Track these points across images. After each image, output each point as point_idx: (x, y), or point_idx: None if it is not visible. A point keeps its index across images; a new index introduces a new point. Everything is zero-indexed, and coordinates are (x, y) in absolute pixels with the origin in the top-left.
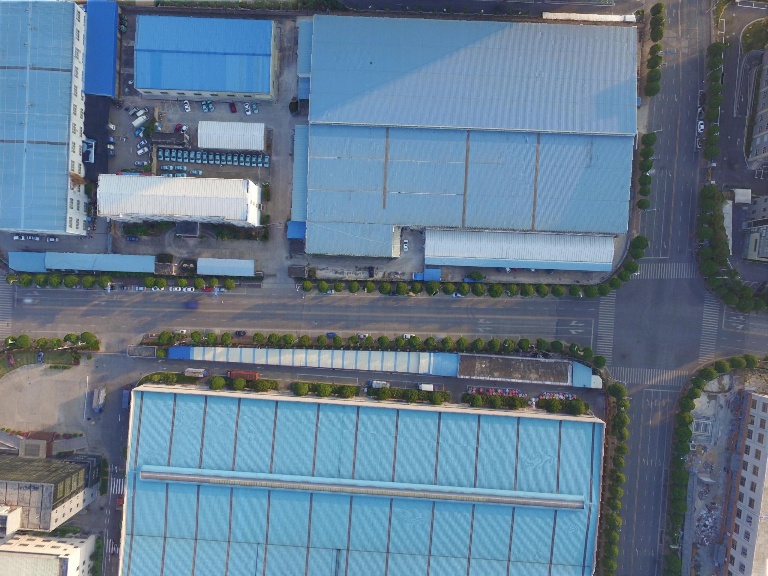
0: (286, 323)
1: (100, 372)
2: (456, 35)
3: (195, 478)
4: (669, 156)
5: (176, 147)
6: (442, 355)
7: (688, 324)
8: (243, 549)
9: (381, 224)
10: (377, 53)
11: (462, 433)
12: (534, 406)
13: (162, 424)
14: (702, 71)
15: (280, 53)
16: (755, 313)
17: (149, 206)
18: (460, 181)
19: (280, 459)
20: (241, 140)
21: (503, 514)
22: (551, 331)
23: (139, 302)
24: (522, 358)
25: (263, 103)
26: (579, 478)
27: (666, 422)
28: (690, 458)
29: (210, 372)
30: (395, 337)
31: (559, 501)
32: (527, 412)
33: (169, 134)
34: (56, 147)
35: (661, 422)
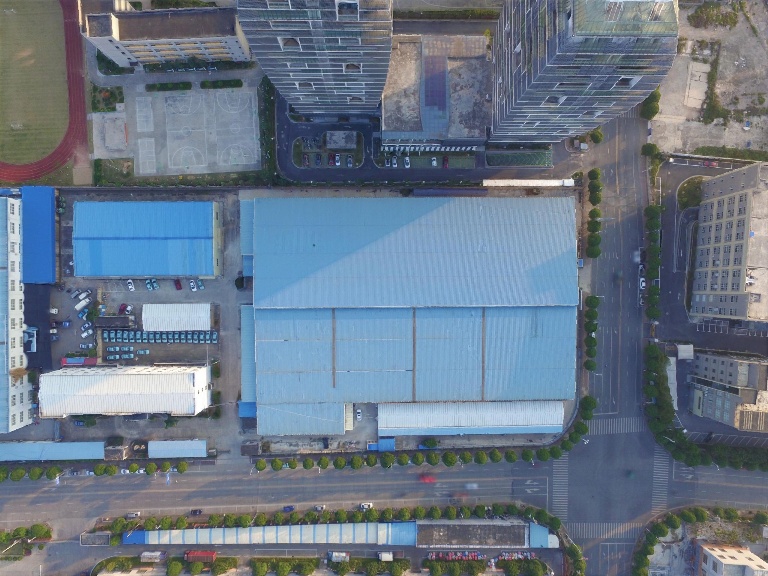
0: (242, 499)
1: (53, 560)
2: (398, 213)
3: None
4: (613, 313)
5: (121, 329)
6: (400, 525)
7: (640, 477)
8: None
9: (332, 403)
10: (319, 234)
11: None
12: (494, 567)
13: None
14: (641, 229)
15: (224, 227)
16: None
17: (93, 405)
18: (408, 357)
19: None
20: (187, 322)
21: None
22: (507, 491)
23: (90, 486)
24: (479, 524)
25: None
26: None
27: (623, 574)
28: None
29: (167, 554)
30: (353, 506)
31: None
32: None
33: (113, 318)
34: None
35: (618, 574)
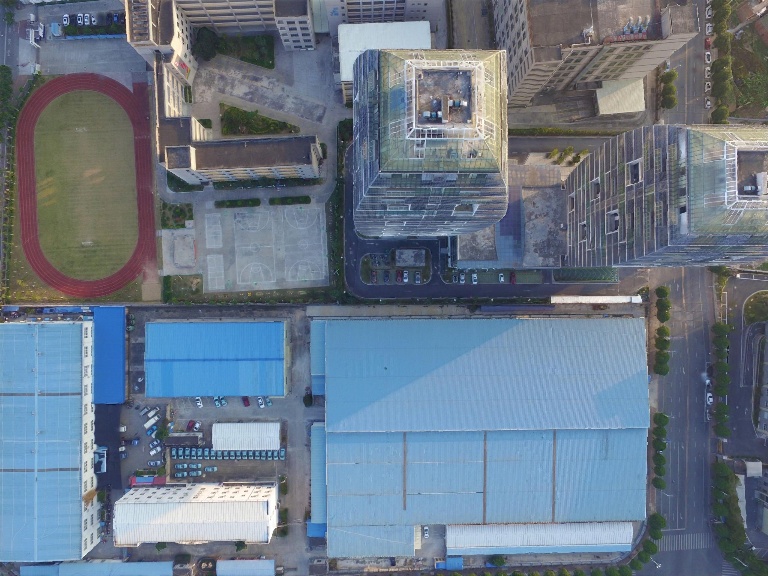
0: None
1: None
2: (468, 335)
3: None
4: (680, 428)
5: (190, 446)
6: None
7: None
8: None
9: (402, 525)
10: (391, 357)
11: None
12: None
13: None
14: (708, 343)
15: (291, 343)
16: None
17: (167, 534)
18: (479, 479)
19: None
20: (256, 442)
21: None
22: None
23: None
24: None
25: None
26: None
27: None
28: None
29: None
30: None
31: None
32: None
33: (183, 438)
34: (68, 473)
35: None
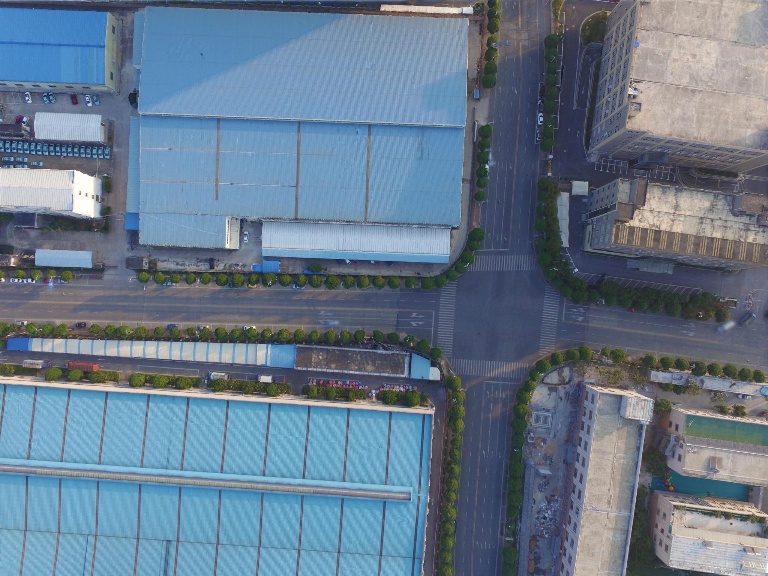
0: (127, 315)
1: None
2: (287, 27)
3: (22, 469)
4: (509, 148)
5: (16, 138)
6: (279, 347)
7: (528, 316)
8: (73, 540)
9: (214, 215)
10: (208, 44)
11: (292, 424)
12: (374, 398)
13: None
14: (542, 63)
15: (122, 45)
16: (595, 305)
17: None
18: (292, 172)
19: (109, 450)
20: (77, 131)
21: (332, 505)
22: (392, 323)
23: None
24: (359, 350)
25: (105, 95)
26: (408, 469)
27: (506, 414)
28: (530, 450)
29: (50, 363)
30: None
31: (386, 492)
32: (362, 404)
33: (6, 125)
34: None
35: (501, 414)
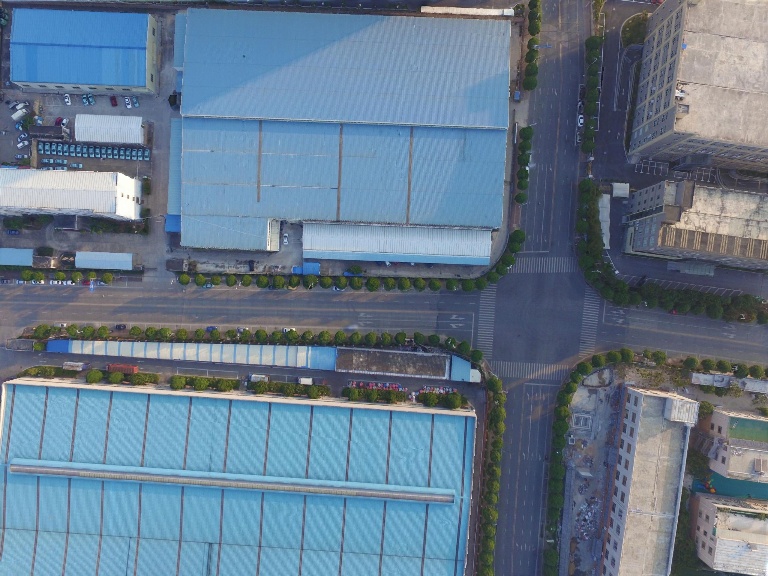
0: (167, 317)
1: None
2: (329, 28)
3: (65, 471)
4: (549, 150)
5: (56, 140)
6: (320, 349)
7: (568, 318)
8: (115, 543)
9: (255, 217)
10: (250, 46)
11: (334, 427)
12: (414, 400)
13: (34, 417)
14: (582, 65)
15: (161, 47)
16: (635, 307)
17: (18, 199)
18: (334, 174)
19: (151, 452)
20: (118, 133)
21: (375, 508)
22: (431, 325)
23: (20, 295)
24: (400, 352)
25: (144, 97)
26: (451, 472)
27: (546, 416)
28: (570, 452)
29: (90, 366)
30: None
31: (429, 495)
32: (403, 406)
33: (47, 127)
34: None
35: (541, 416)
